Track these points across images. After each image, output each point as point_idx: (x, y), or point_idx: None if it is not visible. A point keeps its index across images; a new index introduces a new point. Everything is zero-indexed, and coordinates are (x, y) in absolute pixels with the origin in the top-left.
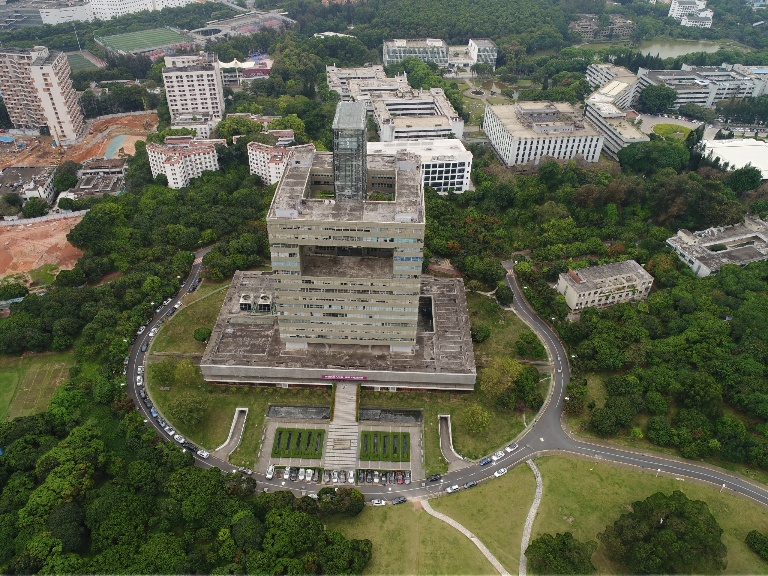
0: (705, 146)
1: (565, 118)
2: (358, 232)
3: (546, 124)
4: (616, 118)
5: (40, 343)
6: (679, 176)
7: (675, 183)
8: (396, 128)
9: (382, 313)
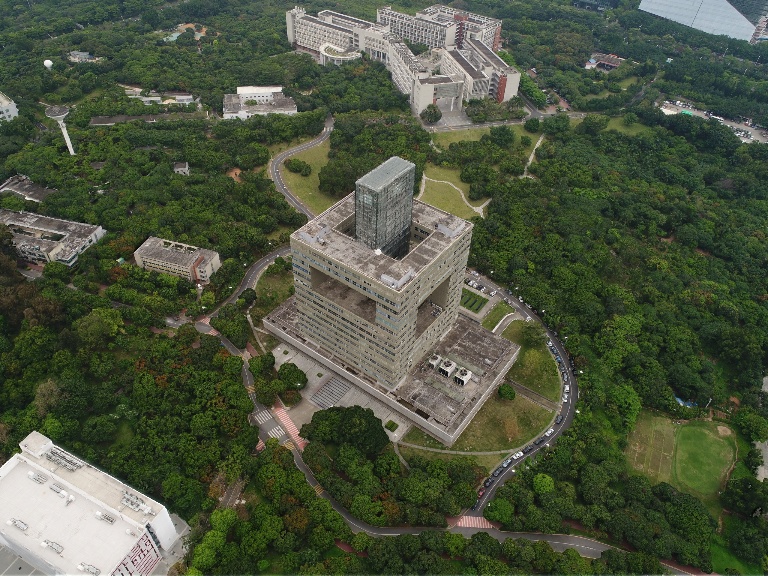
0: None
1: None
2: None
3: None
4: None
5: None
6: None
7: None
8: None
9: None
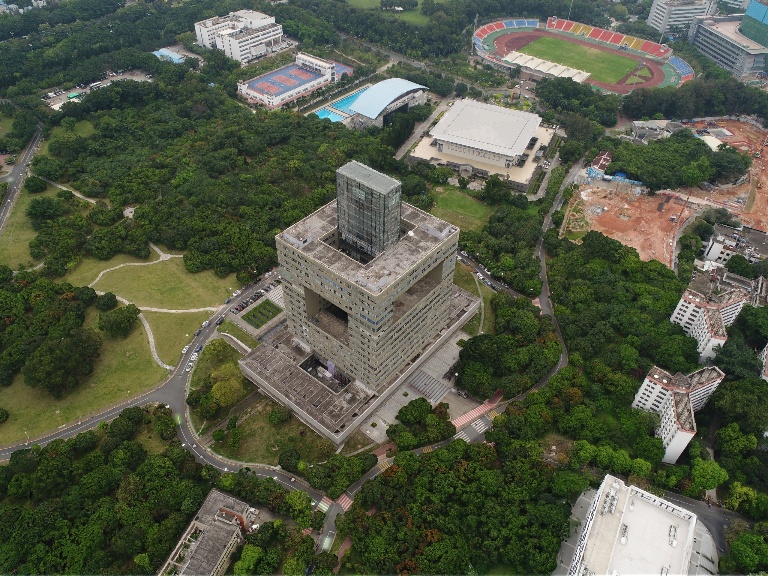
0: None
1: None
2: None
3: None
4: None
5: None
6: None
7: None
8: None
9: None
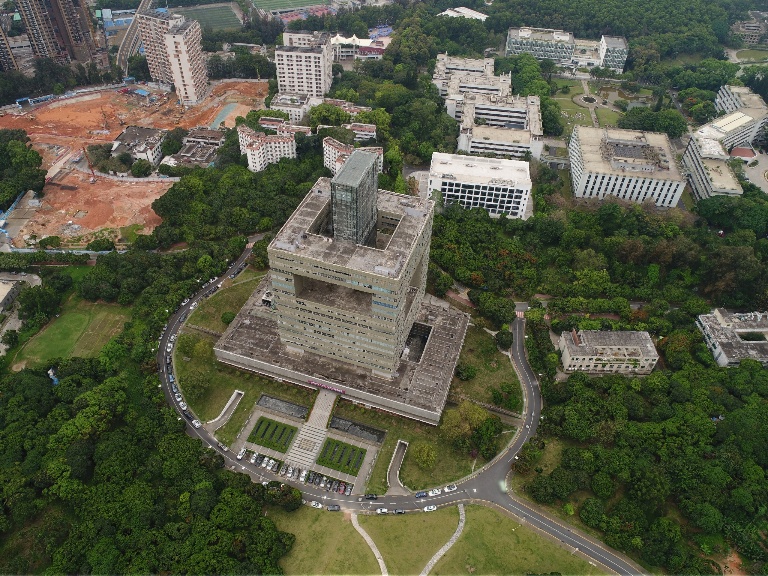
0: None
1: (651, 155)
2: (341, 274)
3: (625, 160)
4: (717, 159)
5: (109, 296)
6: (742, 248)
7: (732, 256)
8: (473, 138)
9: (363, 342)
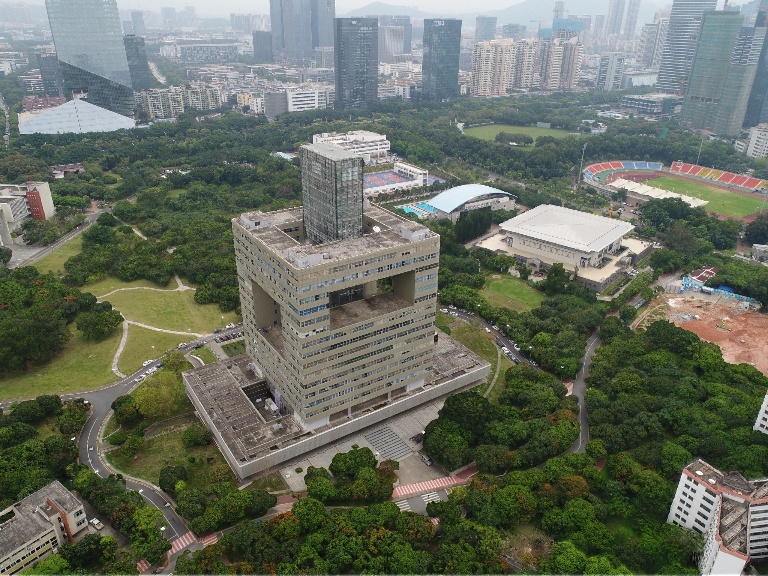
0: None
1: None
2: None
3: None
4: None
5: None
6: None
7: None
8: None
9: None
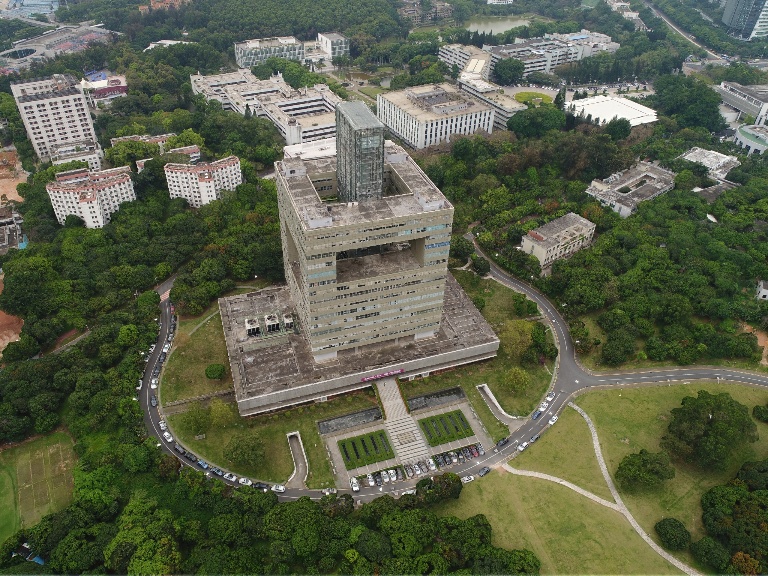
0: (575, 106)
1: (455, 97)
2: (393, 228)
3: (443, 105)
4: (491, 92)
5: (22, 430)
6: (574, 134)
7: (575, 141)
8: (303, 128)
9: (412, 303)
